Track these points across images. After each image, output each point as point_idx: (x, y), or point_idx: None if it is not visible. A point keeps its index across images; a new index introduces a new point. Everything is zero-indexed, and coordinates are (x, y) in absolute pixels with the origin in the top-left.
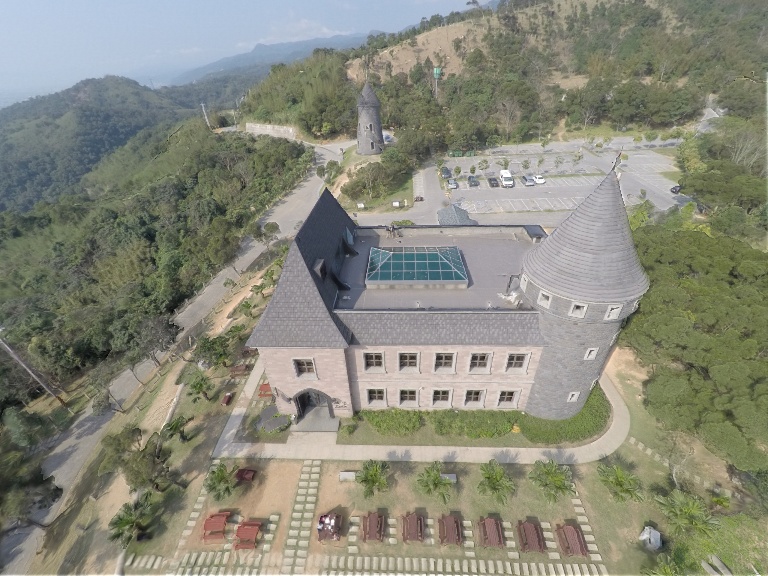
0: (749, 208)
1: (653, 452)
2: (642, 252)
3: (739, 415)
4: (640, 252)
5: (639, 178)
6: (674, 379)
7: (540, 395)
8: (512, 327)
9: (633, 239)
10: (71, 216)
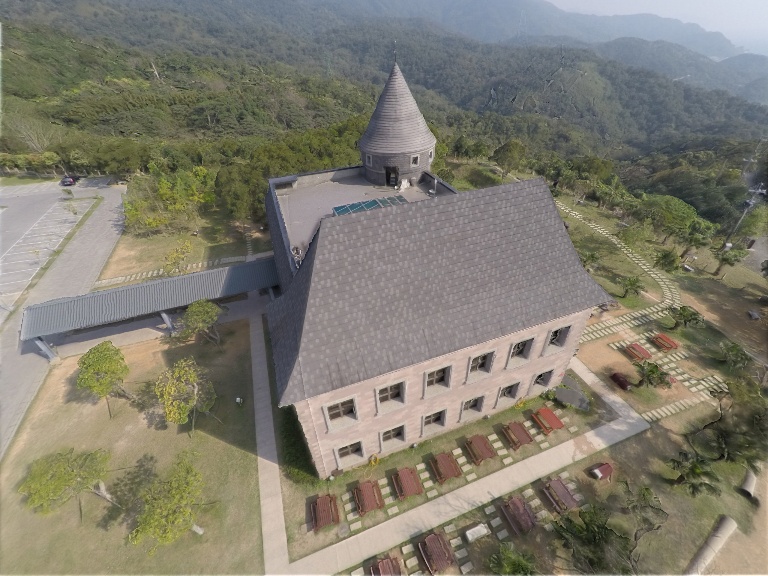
0: None
1: None
2: None
3: None
4: None
5: (2, 196)
6: None
7: None
8: None
9: None
10: None
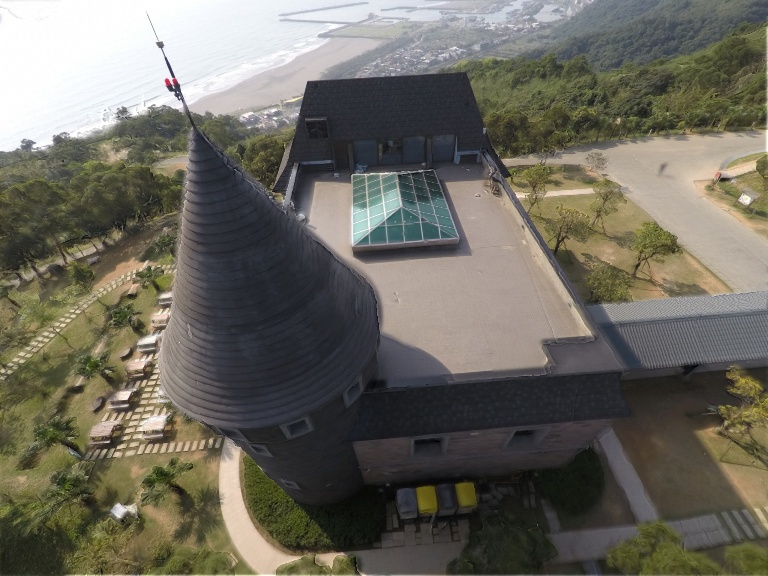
0: None
1: None
2: None
3: None
4: None
5: None
6: None
7: None
8: None
9: (201, 318)
10: (573, 74)
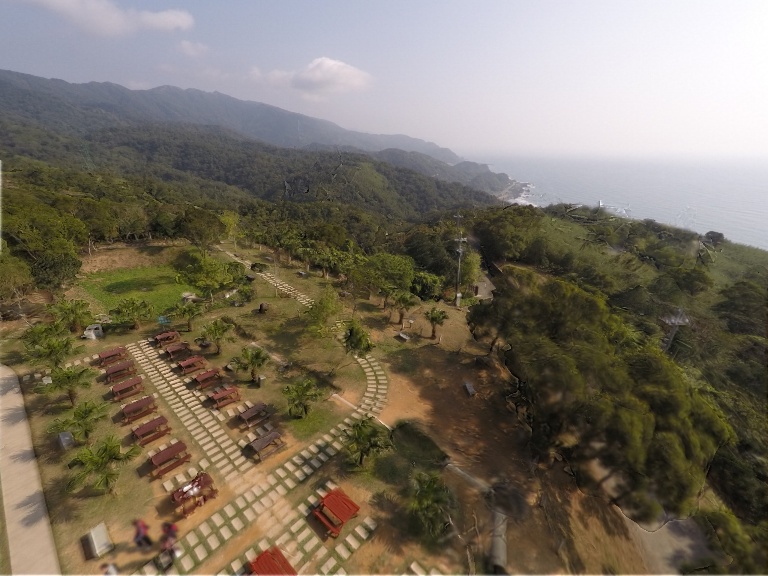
0: None
1: None
2: None
3: None
4: None
5: None
6: None
7: None
8: None
9: None
10: None
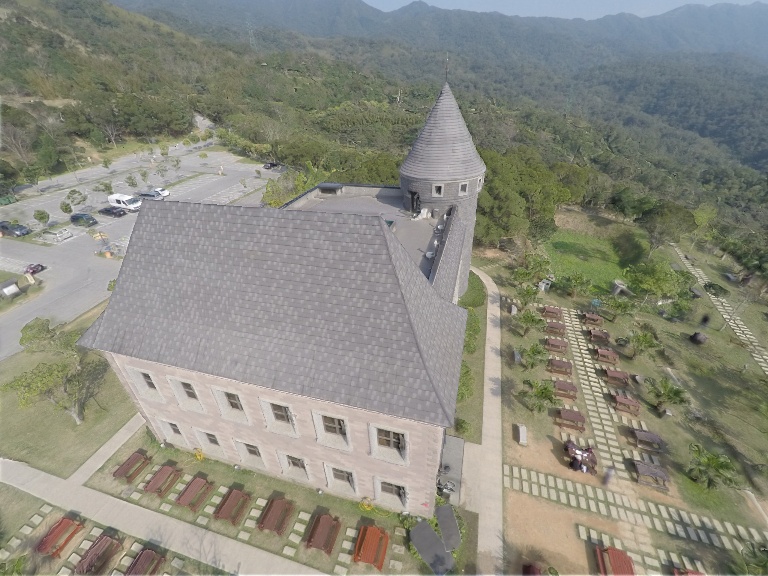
0: (315, 163)
1: (490, 265)
2: (368, 181)
3: (512, 208)
4: (368, 181)
5: (231, 168)
6: (478, 217)
7: (464, 274)
8: (457, 225)
9: None
10: None
